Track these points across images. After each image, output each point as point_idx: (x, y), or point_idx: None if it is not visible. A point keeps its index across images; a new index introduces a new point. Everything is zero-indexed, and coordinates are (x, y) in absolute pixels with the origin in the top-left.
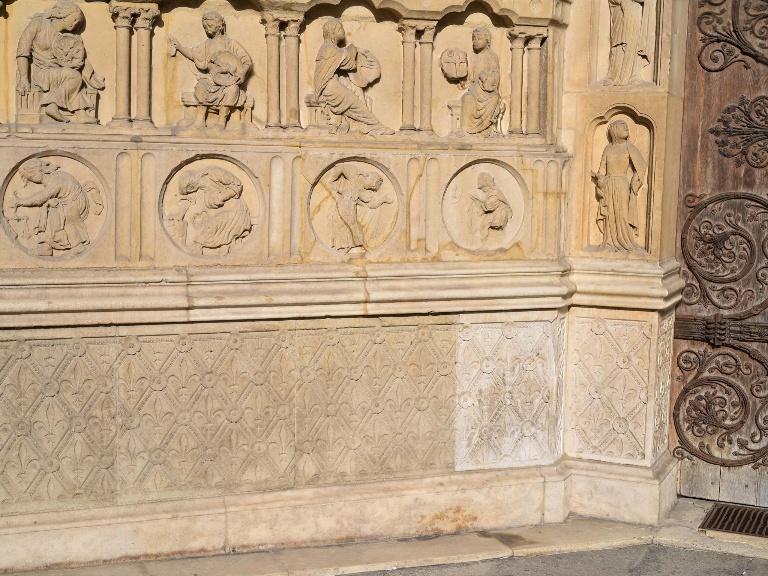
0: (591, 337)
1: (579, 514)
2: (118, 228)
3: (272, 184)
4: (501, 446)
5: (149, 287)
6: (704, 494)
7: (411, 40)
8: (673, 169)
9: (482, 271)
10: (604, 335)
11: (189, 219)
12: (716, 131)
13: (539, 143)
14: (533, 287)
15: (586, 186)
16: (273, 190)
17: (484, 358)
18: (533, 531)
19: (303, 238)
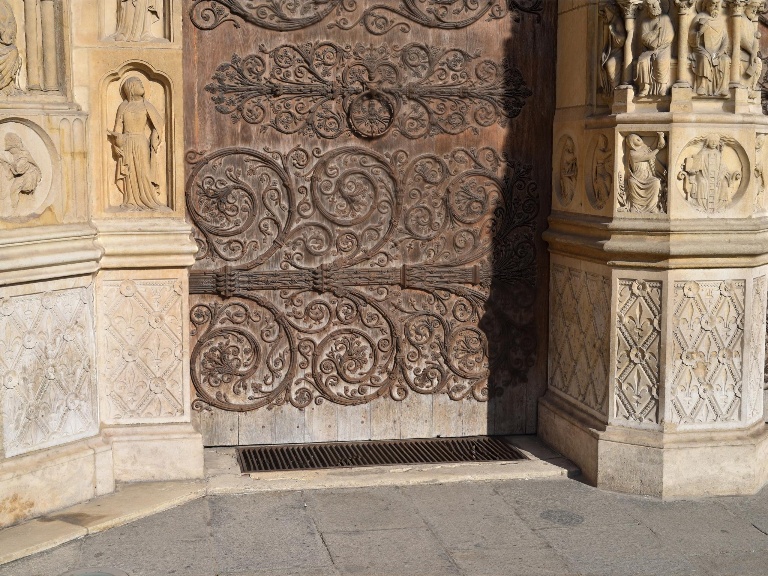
0: (121, 300)
1: (124, 481)
2: None
3: None
4: (48, 424)
5: None
6: (224, 441)
7: None
8: None
9: (20, 239)
10: (134, 296)
11: None
12: (212, 88)
13: (60, 100)
14: (70, 253)
15: (103, 145)
16: None
17: (26, 333)
18: (92, 506)
19: None
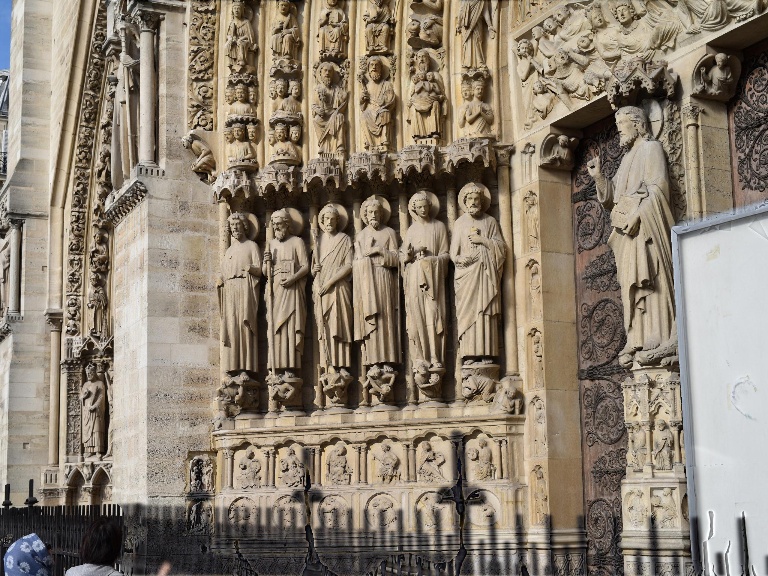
0: None
1: None
2: (353, 519)
3: (402, 502)
4: None
5: (362, 539)
6: None
7: (454, 447)
8: (569, 489)
9: (480, 533)
10: None
11: (376, 516)
12: None
13: (507, 482)
14: (501, 540)
15: (533, 498)
16: (403, 504)
17: (485, 569)
18: None
19: (414, 521)
